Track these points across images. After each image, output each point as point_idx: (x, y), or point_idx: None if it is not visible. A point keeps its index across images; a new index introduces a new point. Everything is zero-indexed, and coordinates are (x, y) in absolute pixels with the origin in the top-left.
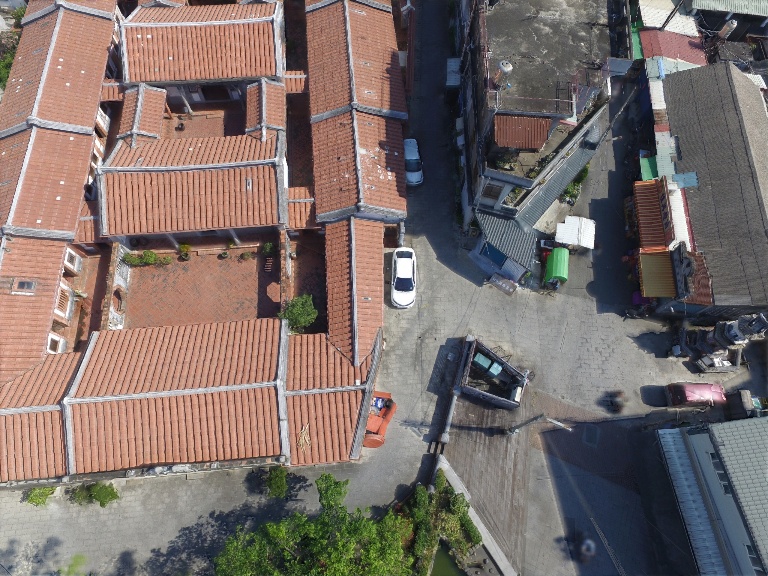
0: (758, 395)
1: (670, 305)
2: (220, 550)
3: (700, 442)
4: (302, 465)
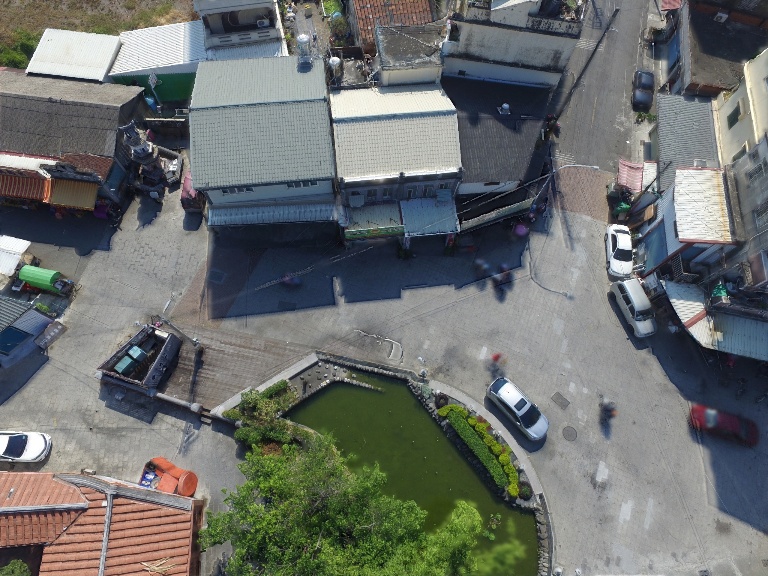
0: None
1: (109, 190)
2: None
3: (216, 198)
4: (189, 567)
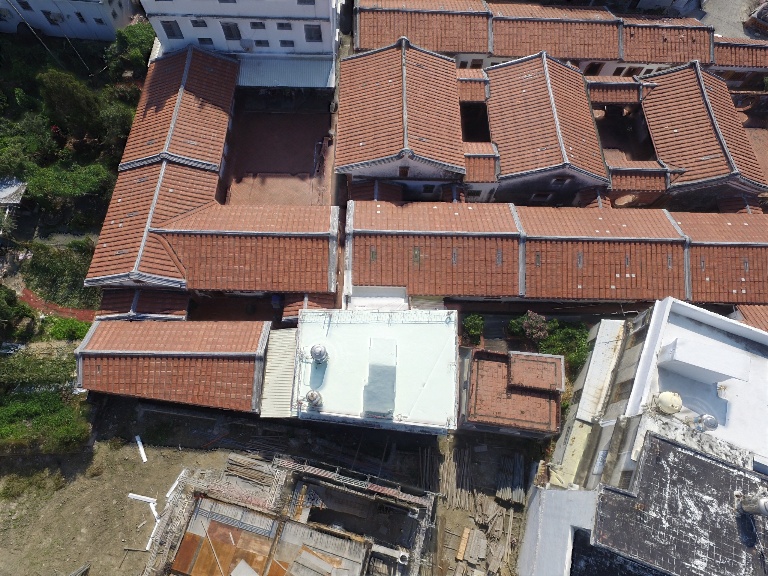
0: None
1: None
2: None
3: None
4: None
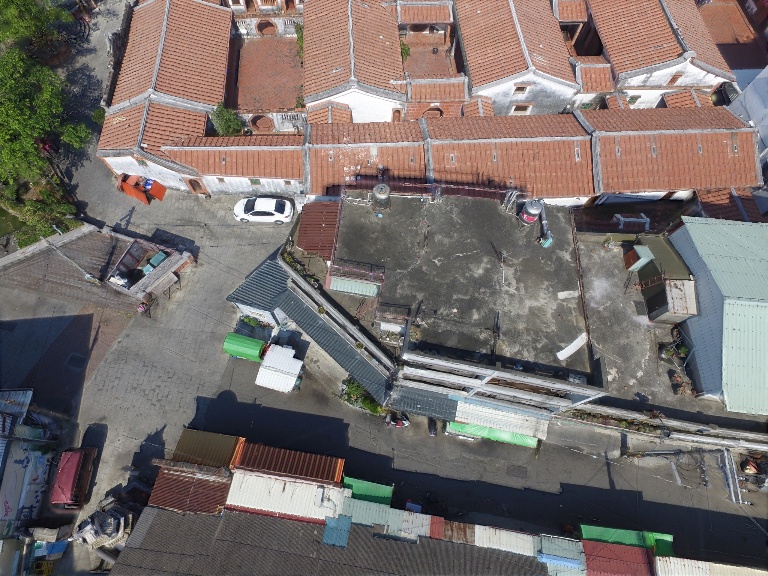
0: (59, 572)
1: None
2: (82, 101)
3: None
4: None
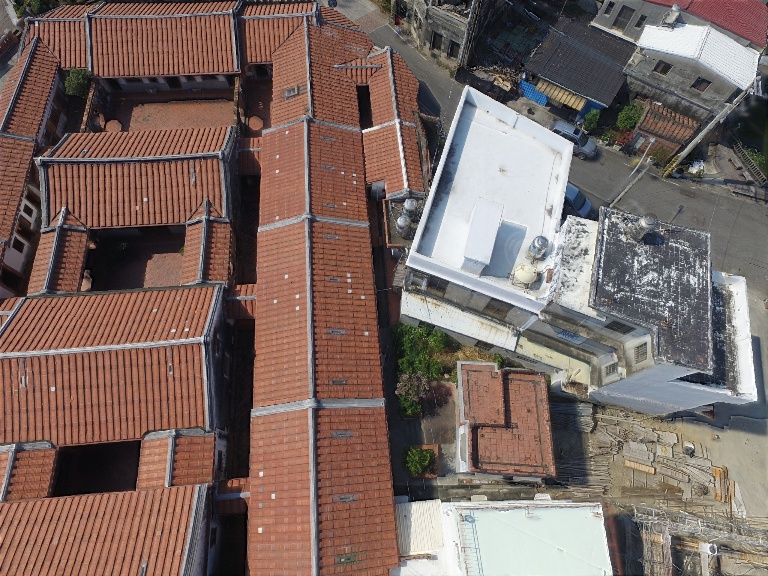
0: None
1: None
2: None
3: None
4: None
